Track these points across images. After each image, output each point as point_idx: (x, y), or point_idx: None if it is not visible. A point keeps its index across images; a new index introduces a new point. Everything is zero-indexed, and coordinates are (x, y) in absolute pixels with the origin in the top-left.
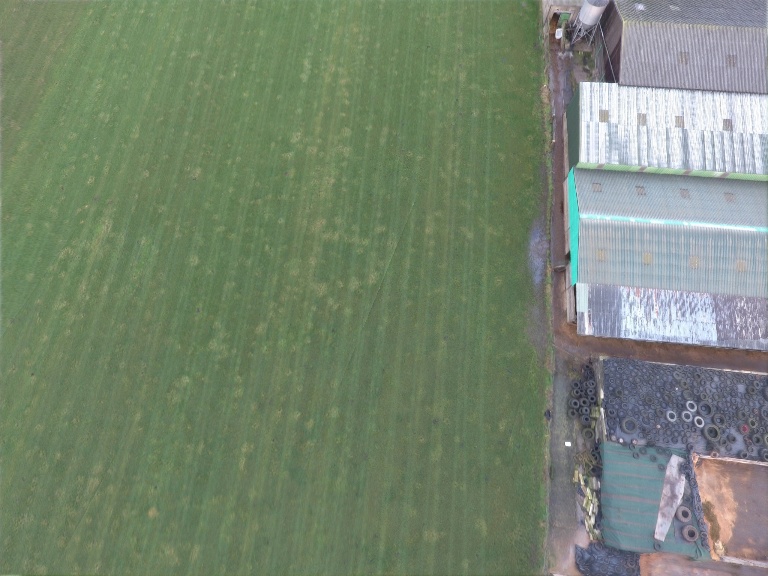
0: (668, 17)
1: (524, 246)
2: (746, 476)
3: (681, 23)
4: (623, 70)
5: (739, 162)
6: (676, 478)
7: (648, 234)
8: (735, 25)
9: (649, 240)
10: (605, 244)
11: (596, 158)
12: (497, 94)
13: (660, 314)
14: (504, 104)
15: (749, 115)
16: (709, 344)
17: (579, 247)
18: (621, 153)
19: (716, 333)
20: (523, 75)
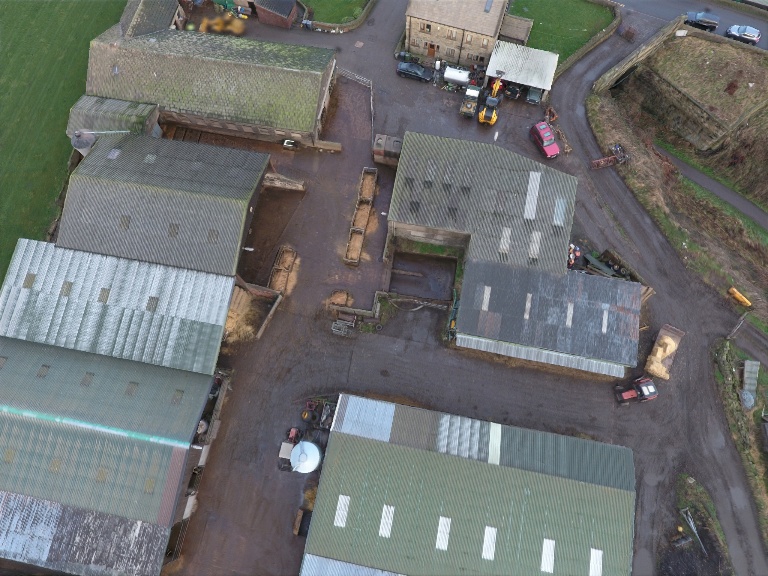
0: (126, 172)
1: None
2: None
3: (130, 182)
4: (62, 230)
5: (148, 350)
6: None
7: (17, 427)
8: (186, 189)
9: (16, 435)
10: None
11: (5, 330)
12: (1, 226)
13: None
14: (4, 239)
15: (178, 294)
16: (37, 564)
17: None
18: (31, 326)
19: (48, 552)
20: (40, 205)
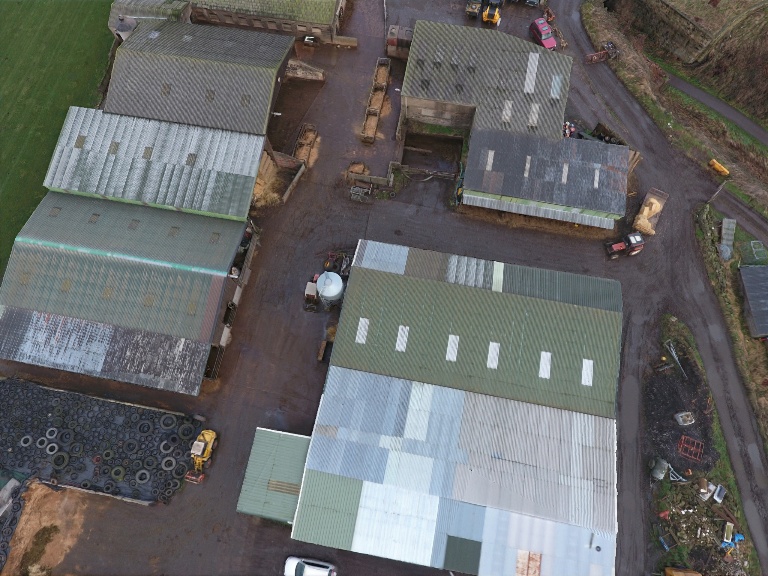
0: (167, 47)
1: (4, 263)
2: (104, 505)
3: (170, 55)
4: (109, 97)
5: (188, 197)
6: (4, 501)
7: (72, 262)
8: (221, 60)
9: (72, 268)
10: (31, 268)
11: (59, 183)
12: (48, 110)
13: (59, 341)
14: (51, 121)
15: (214, 151)
16: (92, 374)
17: (6, 269)
18: (83, 180)
19: (102, 364)
20: (83, 93)
